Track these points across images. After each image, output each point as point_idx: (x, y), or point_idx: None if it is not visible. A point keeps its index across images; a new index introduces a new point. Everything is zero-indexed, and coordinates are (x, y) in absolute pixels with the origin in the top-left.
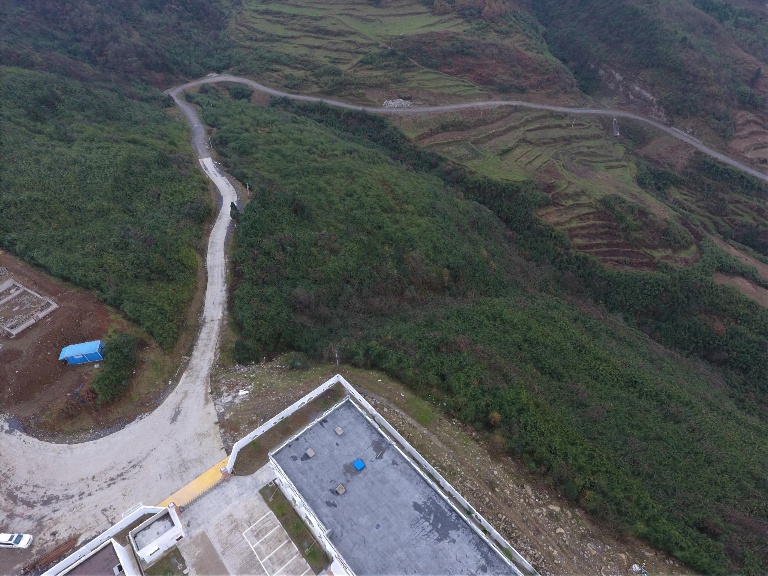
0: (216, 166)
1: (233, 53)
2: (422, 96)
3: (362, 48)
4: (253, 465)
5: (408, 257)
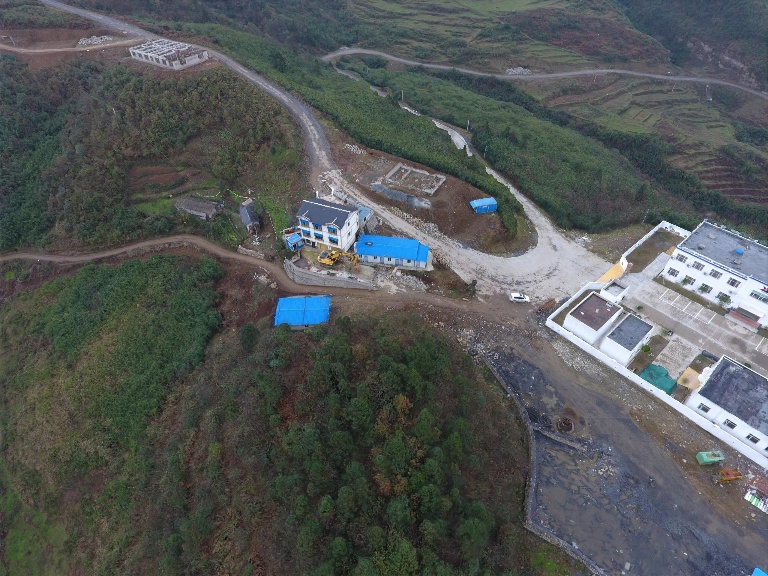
0: (417, 113)
1: (361, 29)
2: (538, 65)
3: (478, 23)
4: (637, 268)
5: (602, 180)
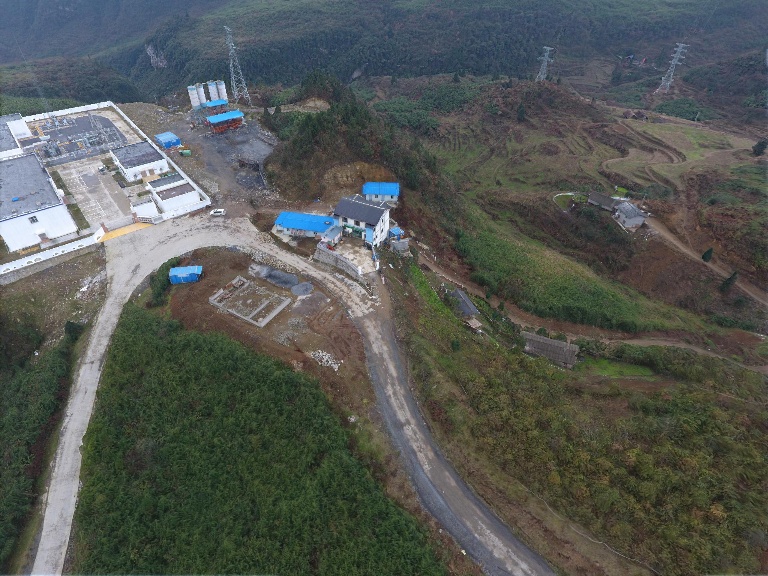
0: None
1: None
2: None
3: None
4: None
5: None
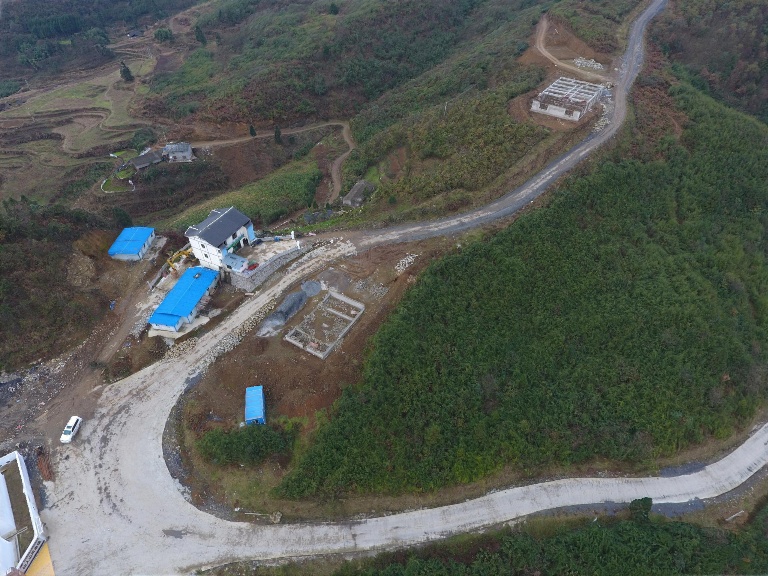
0: None
1: None
2: None
3: None
4: None
5: None
